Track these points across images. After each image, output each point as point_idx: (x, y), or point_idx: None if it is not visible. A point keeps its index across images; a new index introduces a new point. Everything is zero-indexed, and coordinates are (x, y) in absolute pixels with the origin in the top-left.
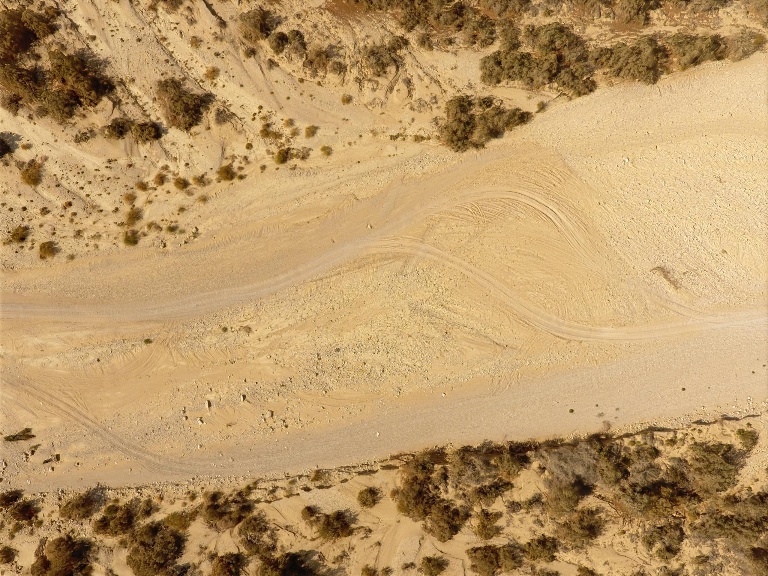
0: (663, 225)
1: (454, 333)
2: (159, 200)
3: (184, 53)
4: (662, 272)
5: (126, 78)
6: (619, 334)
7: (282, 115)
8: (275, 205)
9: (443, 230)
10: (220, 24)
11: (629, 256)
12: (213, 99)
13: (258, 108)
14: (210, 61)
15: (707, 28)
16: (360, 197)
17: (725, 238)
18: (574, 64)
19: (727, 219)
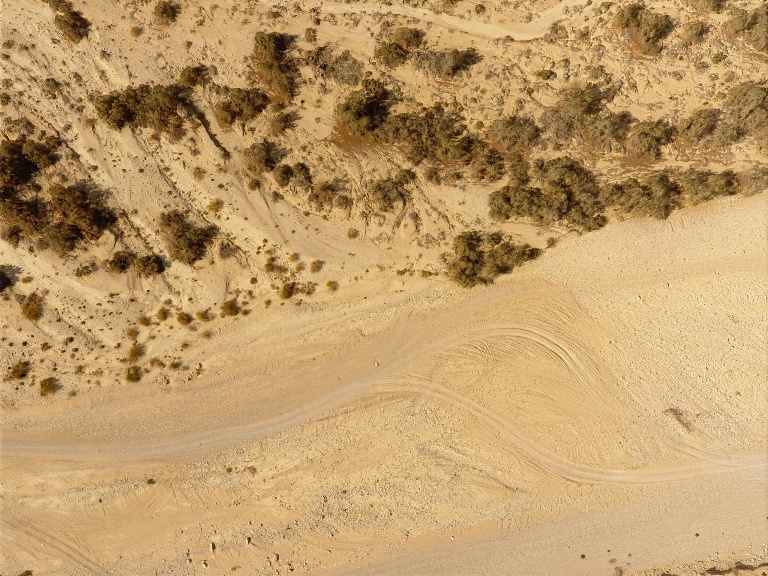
0: (675, 365)
1: (463, 475)
2: (162, 335)
3: (187, 184)
4: (675, 415)
5: (128, 209)
6: (631, 477)
7: (287, 249)
8: (280, 341)
9: (451, 369)
10: (224, 156)
11: (641, 397)
12: (217, 232)
13: (263, 241)
14: (214, 193)
15: (719, 164)
16: (367, 333)
17: (739, 379)
18: (584, 200)
19: (741, 360)
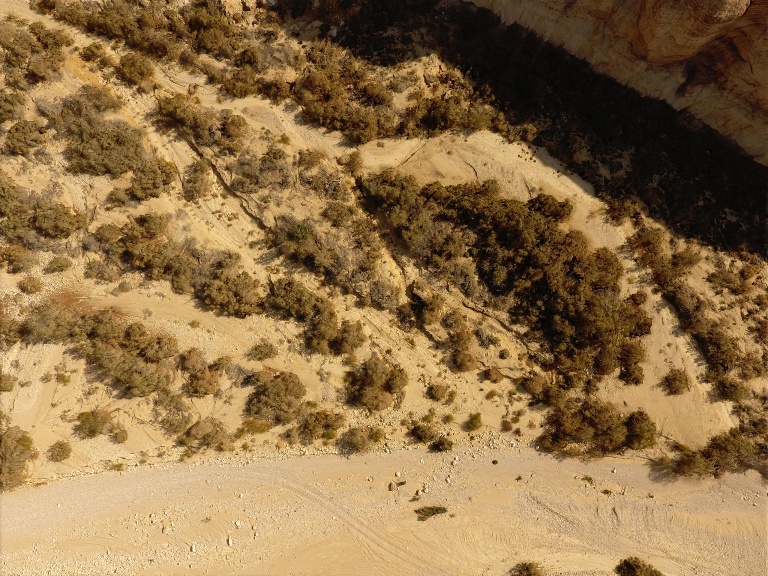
0: None
1: None
2: None
3: None
4: None
5: None
6: None
7: None
8: None
9: None
10: None
11: None
12: None
13: None
14: None
15: None
16: None
17: None
18: None
19: None
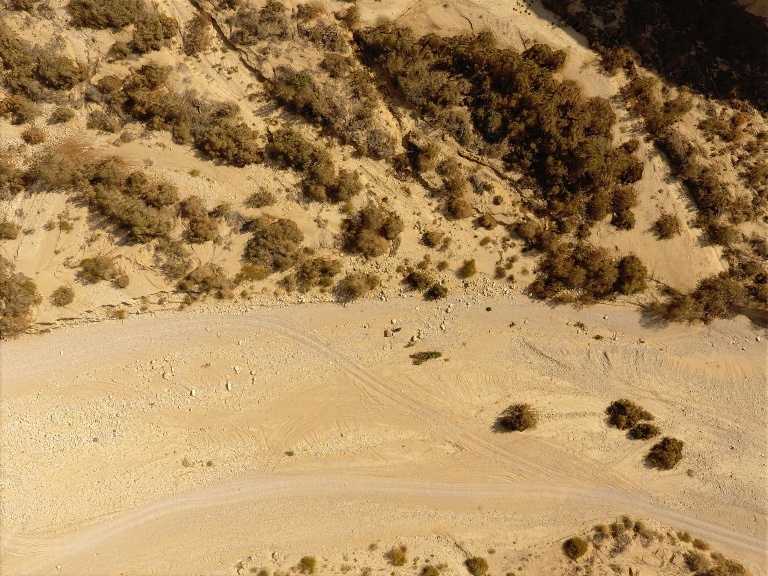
0: None
1: None
2: None
3: None
4: None
5: None
6: None
7: None
8: None
9: None
10: None
11: None
12: None
13: None
14: None
15: None
16: None
17: None
18: None
19: None
